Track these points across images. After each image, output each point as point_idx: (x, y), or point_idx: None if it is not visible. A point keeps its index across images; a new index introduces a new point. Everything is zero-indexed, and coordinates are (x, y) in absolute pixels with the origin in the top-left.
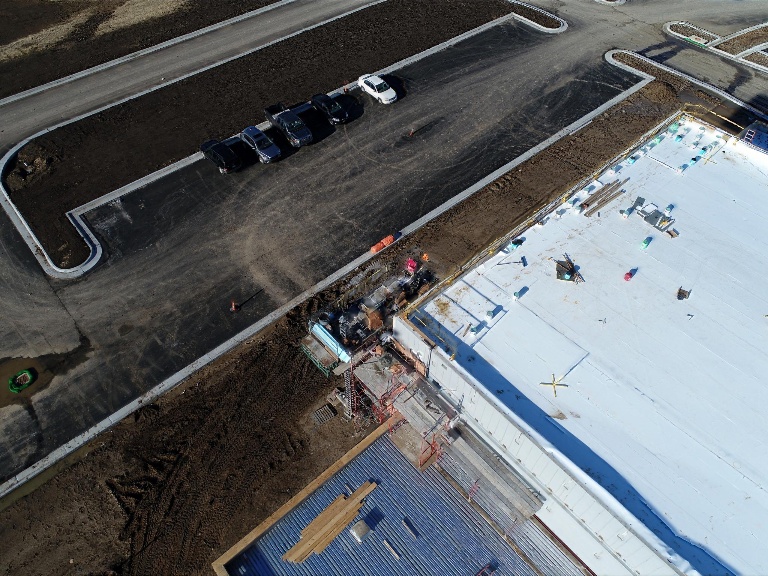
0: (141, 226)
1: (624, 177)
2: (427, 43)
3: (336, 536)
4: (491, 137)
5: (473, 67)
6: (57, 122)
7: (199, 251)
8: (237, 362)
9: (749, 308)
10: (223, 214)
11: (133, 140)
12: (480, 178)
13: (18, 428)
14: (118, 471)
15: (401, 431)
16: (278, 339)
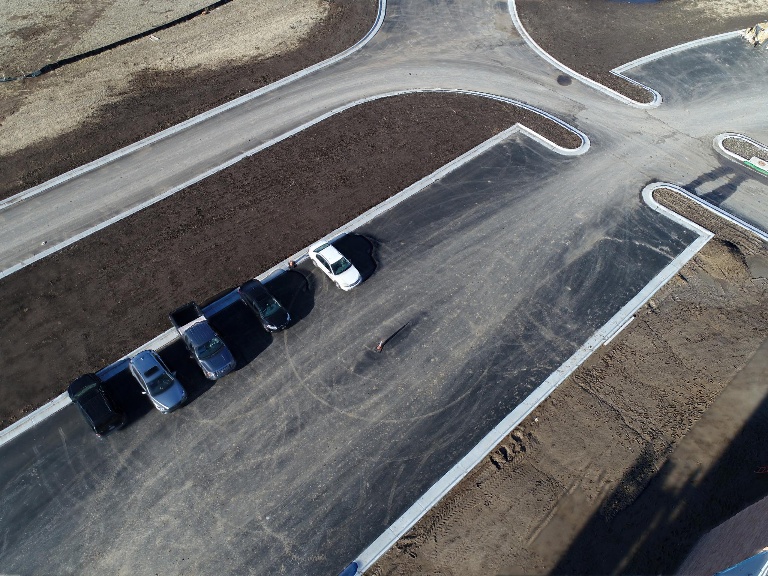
0: None
1: None
2: (406, 177)
3: None
4: (493, 351)
5: (467, 217)
6: None
7: None
8: None
9: None
10: (86, 523)
11: None
12: (478, 438)
13: None
14: None
15: None
16: None
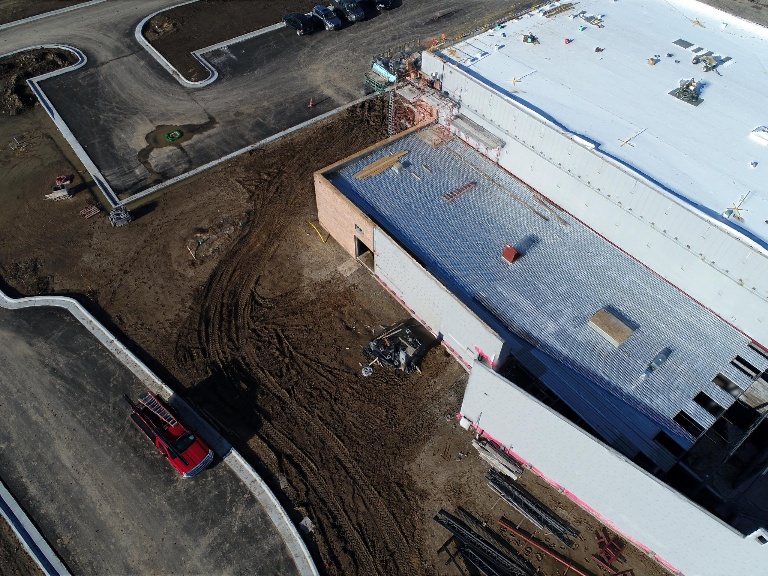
0: (244, 62)
1: (576, 2)
2: None
3: (384, 170)
4: None
5: None
6: (175, 4)
7: (285, 77)
8: (314, 130)
9: (638, 56)
10: (301, 58)
11: (233, 14)
12: None
13: (175, 156)
14: (242, 176)
15: (423, 133)
16: (341, 121)
